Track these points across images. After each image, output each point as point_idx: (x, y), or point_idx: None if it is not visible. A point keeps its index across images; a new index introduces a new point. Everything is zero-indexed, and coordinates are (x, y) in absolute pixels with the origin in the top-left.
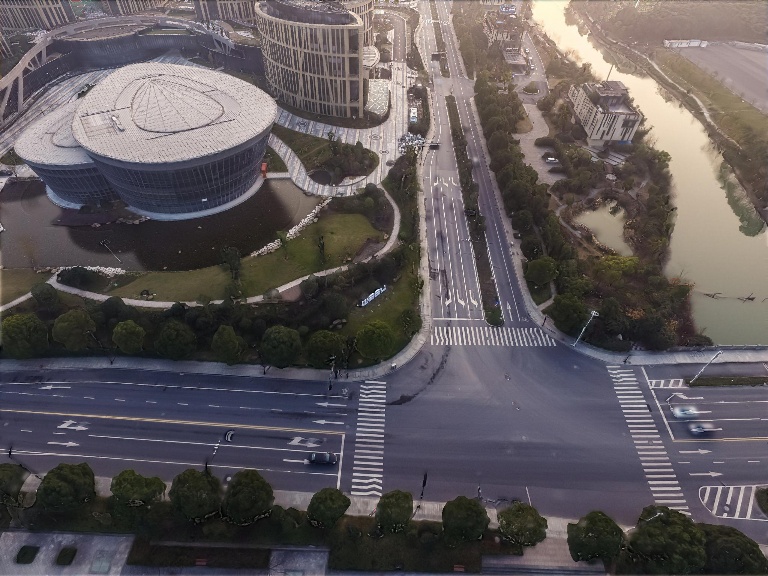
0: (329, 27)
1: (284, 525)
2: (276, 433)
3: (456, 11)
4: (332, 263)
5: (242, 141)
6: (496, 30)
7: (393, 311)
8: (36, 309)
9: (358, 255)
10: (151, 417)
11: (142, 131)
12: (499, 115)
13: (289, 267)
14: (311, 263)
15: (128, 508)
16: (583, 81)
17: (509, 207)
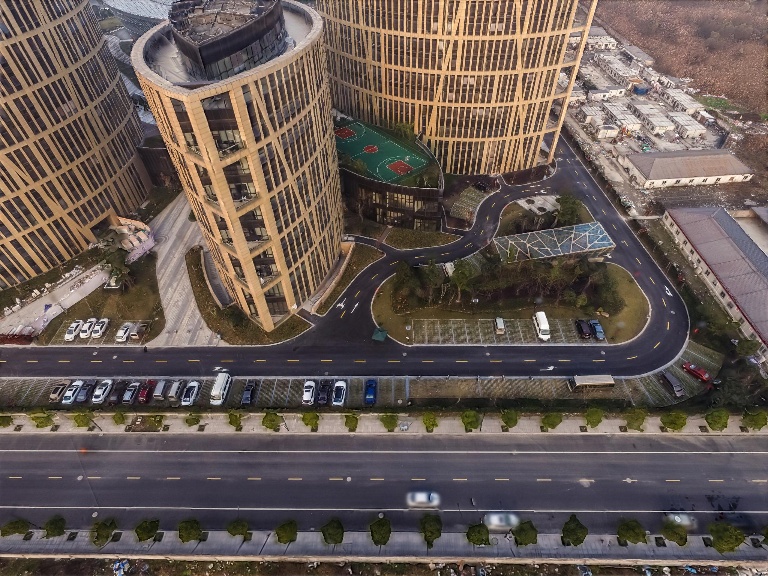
0: None
1: None
2: None
3: None
4: None
5: None
6: None
7: None
8: None
9: None
10: None
11: None
12: None
13: None
14: None
15: None
16: None
17: None
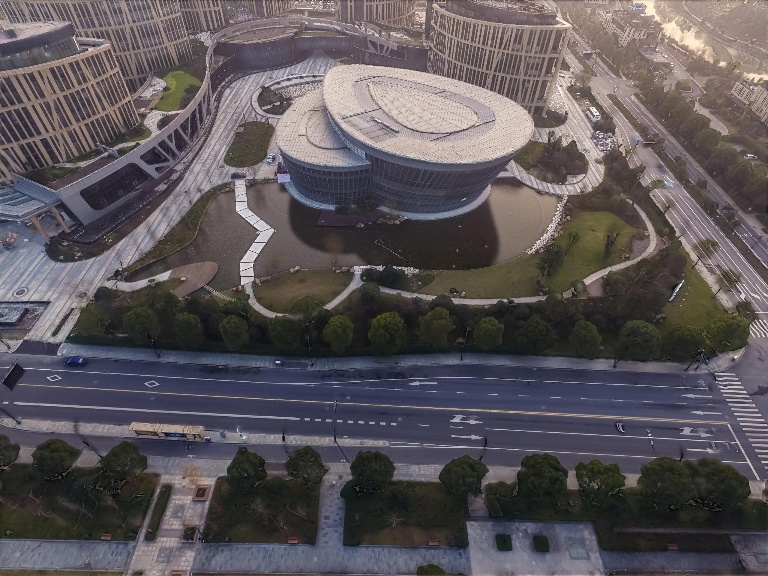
0: (538, 28)
1: (747, 510)
2: (663, 424)
3: (573, 10)
4: (613, 260)
5: (526, 141)
6: (634, 29)
7: (700, 305)
8: (362, 308)
9: (632, 251)
10: (534, 410)
11: (417, 132)
12: (691, 113)
13: (575, 264)
14: (593, 260)
15: (607, 496)
16: (734, 78)
17: (746, 203)
